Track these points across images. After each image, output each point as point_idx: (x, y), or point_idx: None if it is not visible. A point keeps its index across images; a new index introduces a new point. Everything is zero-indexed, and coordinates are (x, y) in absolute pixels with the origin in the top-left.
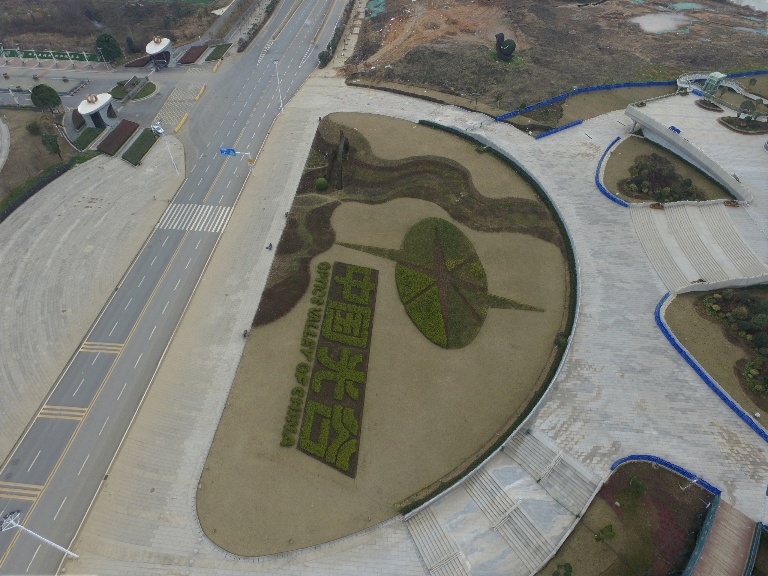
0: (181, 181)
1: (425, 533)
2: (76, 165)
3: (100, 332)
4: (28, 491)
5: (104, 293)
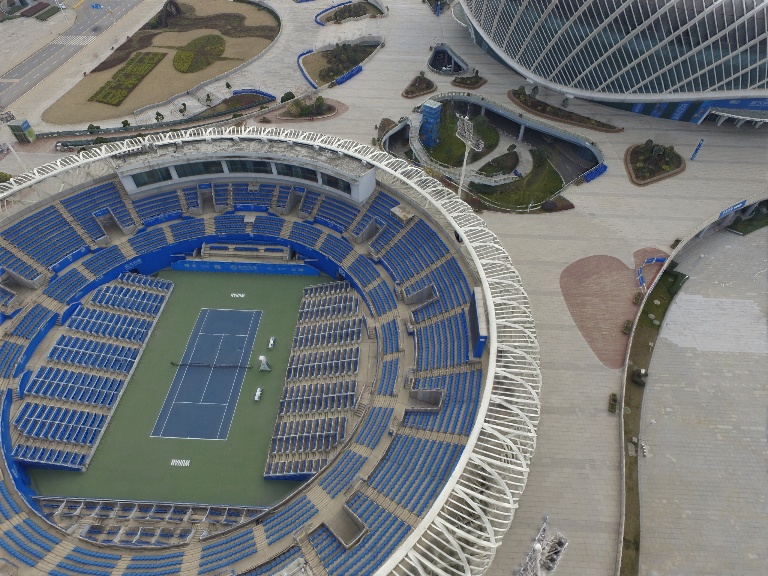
0: (70, 27)
1: (141, 116)
2: (6, 21)
3: (8, 76)
4: None
5: (13, 65)
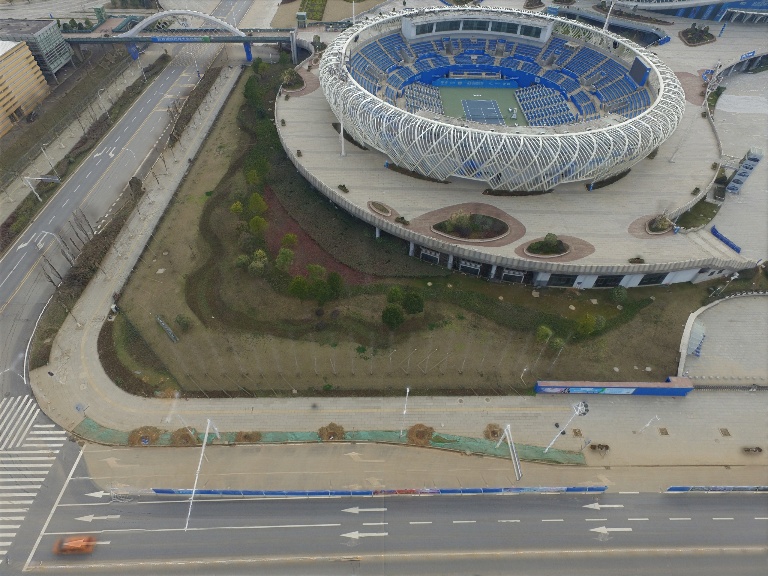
0: None
1: None
2: None
3: (222, 6)
4: None
5: None
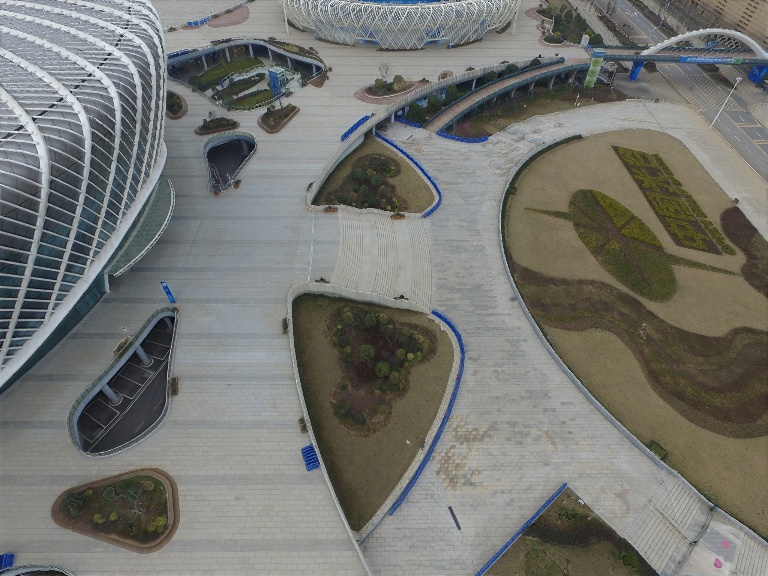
0: None
1: None
2: None
3: None
4: (761, 142)
5: None
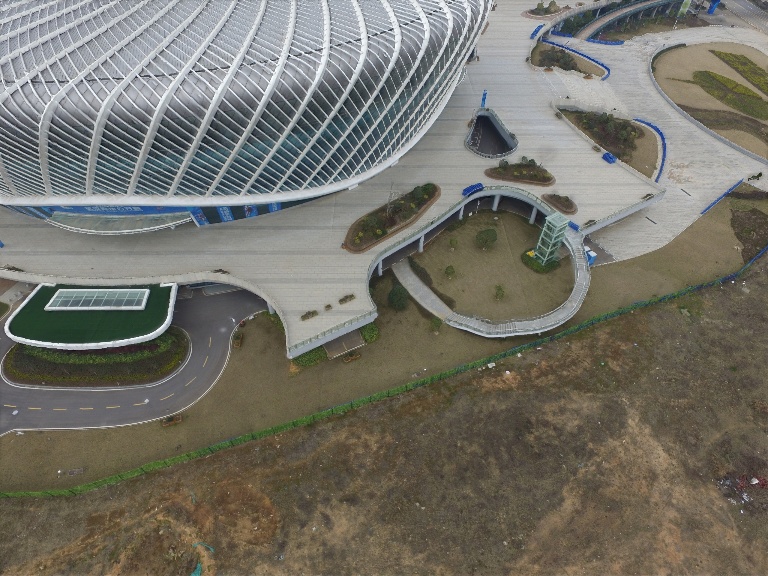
0: None
1: None
2: None
3: None
4: None
5: None
